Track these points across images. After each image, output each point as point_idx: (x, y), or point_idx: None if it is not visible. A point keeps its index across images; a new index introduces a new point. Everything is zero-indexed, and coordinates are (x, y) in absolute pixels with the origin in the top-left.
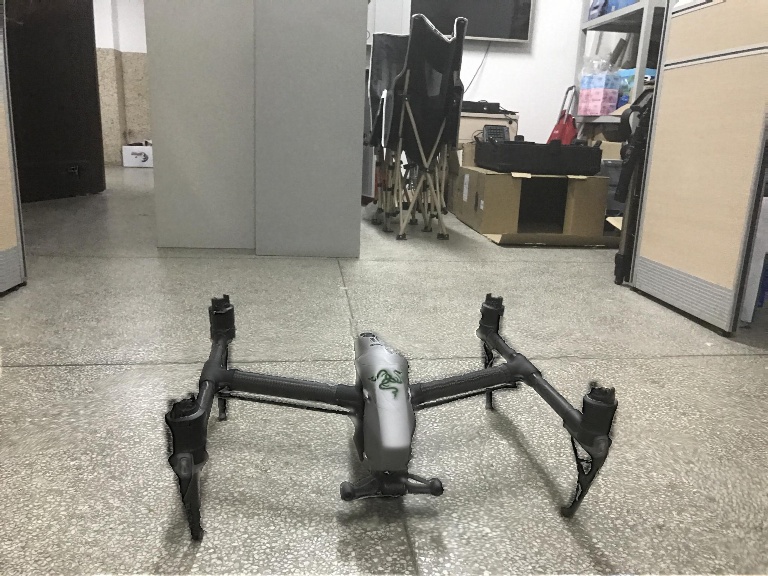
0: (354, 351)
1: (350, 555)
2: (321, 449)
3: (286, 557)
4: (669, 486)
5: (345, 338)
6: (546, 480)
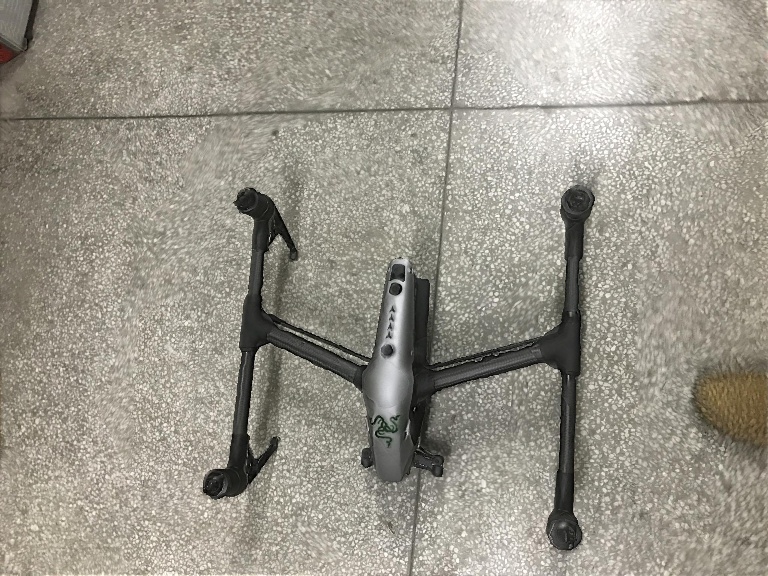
0: (451, 78)
1: (373, 488)
2: (375, 328)
3: (330, 480)
4: (695, 457)
5: (448, 29)
6: None
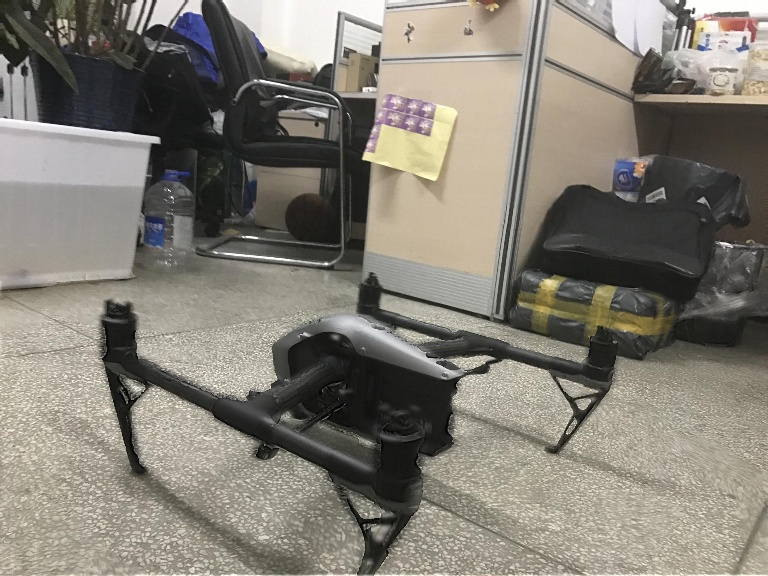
0: None
1: None
2: None
3: None
4: None
5: None
6: (175, 501)
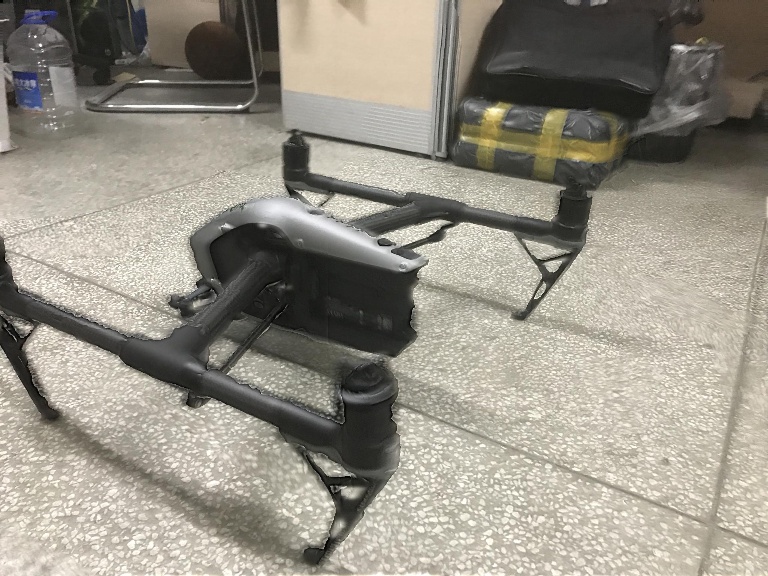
0: None
1: None
2: None
3: None
4: None
5: None
6: (101, 451)
